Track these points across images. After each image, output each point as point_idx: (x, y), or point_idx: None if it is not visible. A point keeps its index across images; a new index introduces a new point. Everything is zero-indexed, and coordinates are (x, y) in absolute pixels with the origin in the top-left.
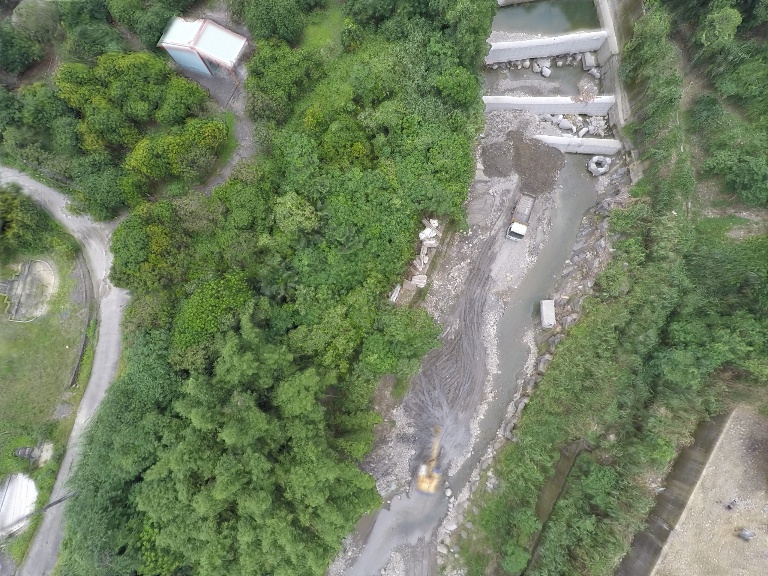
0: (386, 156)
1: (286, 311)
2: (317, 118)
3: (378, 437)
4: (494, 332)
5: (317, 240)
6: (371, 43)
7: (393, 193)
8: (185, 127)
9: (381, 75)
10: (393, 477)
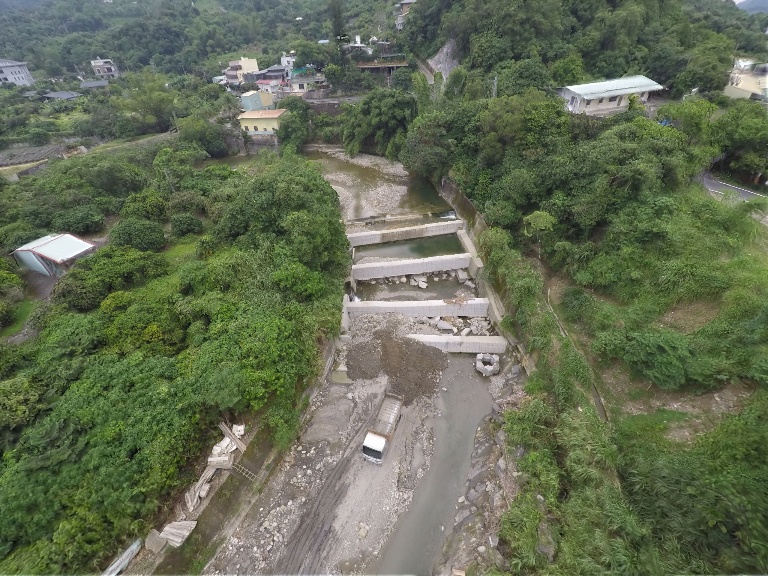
0: (196, 344)
1: None
2: (118, 303)
3: None
4: None
5: (5, 447)
6: (225, 253)
7: None
8: None
9: (214, 270)
10: None
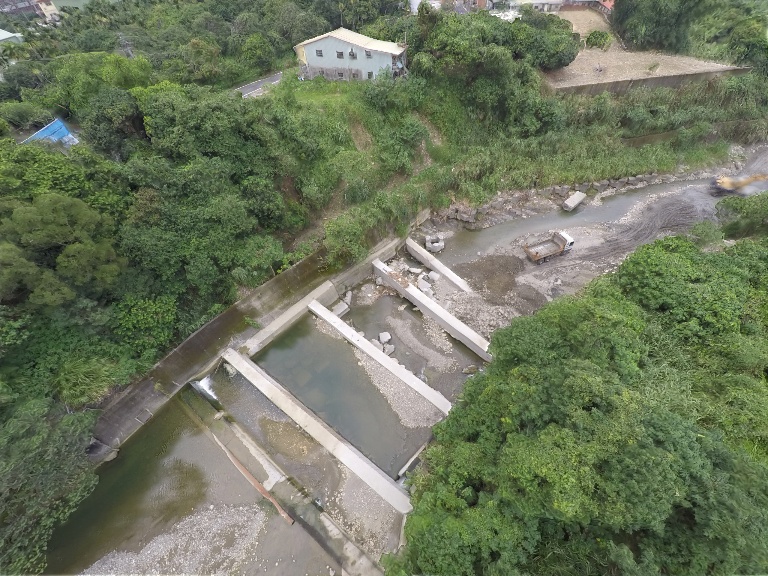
0: None
1: None
2: None
3: None
4: None
5: None
6: None
7: (763, 282)
8: None
9: None
10: None
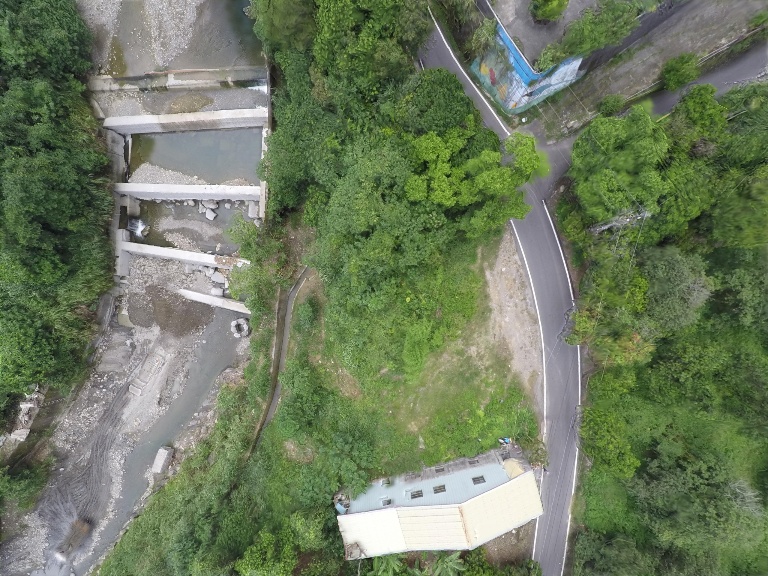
0: None
1: None
2: None
3: (13, 533)
4: (121, 465)
5: None
6: None
7: None
8: None
9: None
10: (28, 560)
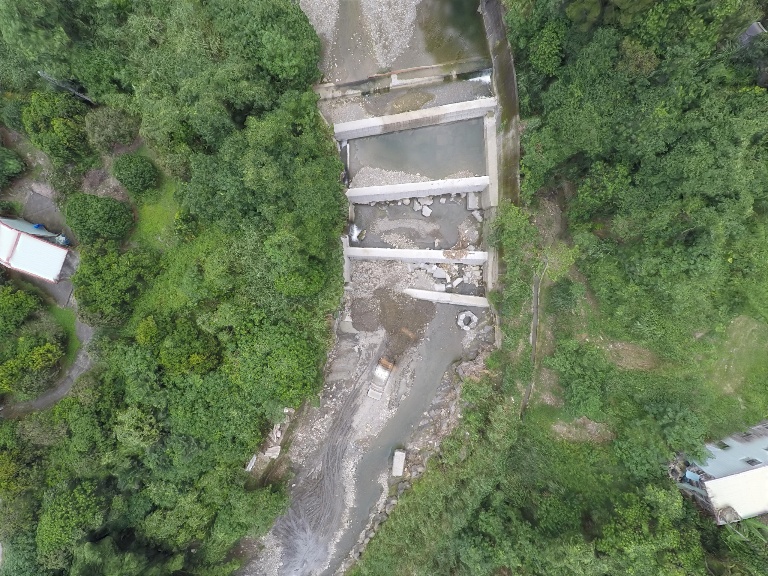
0: (232, 350)
1: (145, 496)
2: (150, 334)
3: (250, 556)
4: (353, 474)
5: None
6: (209, 234)
7: (236, 393)
8: (18, 354)
9: (214, 282)
10: None
